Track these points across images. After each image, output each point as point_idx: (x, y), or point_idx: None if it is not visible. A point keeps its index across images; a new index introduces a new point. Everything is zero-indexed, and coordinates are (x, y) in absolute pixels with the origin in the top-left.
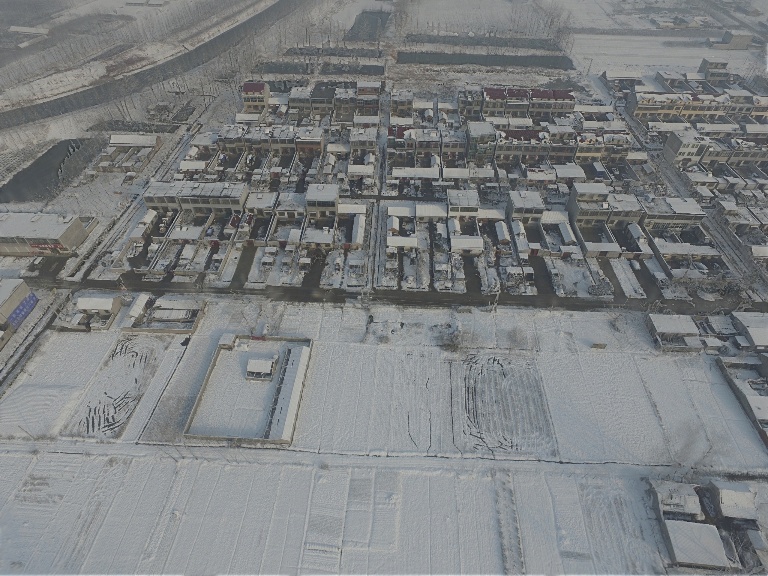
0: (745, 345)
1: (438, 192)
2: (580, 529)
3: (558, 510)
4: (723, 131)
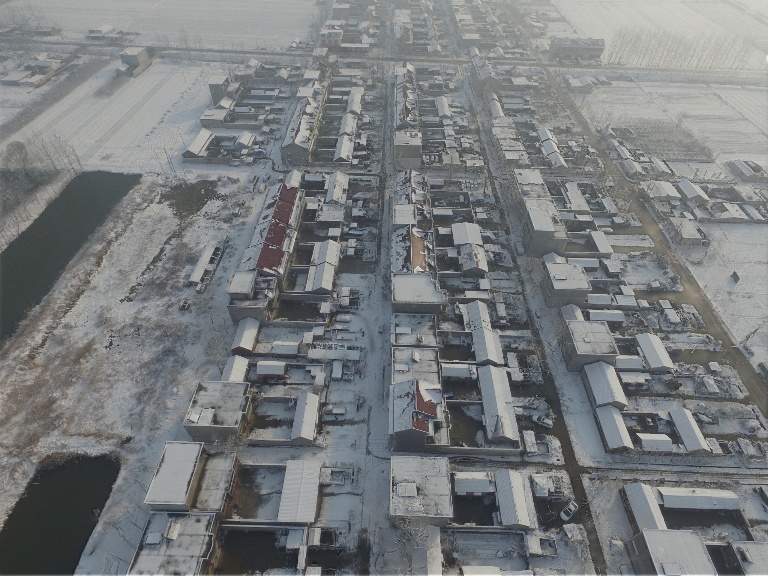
0: (679, 203)
1: None
2: None
3: None
4: (355, 124)
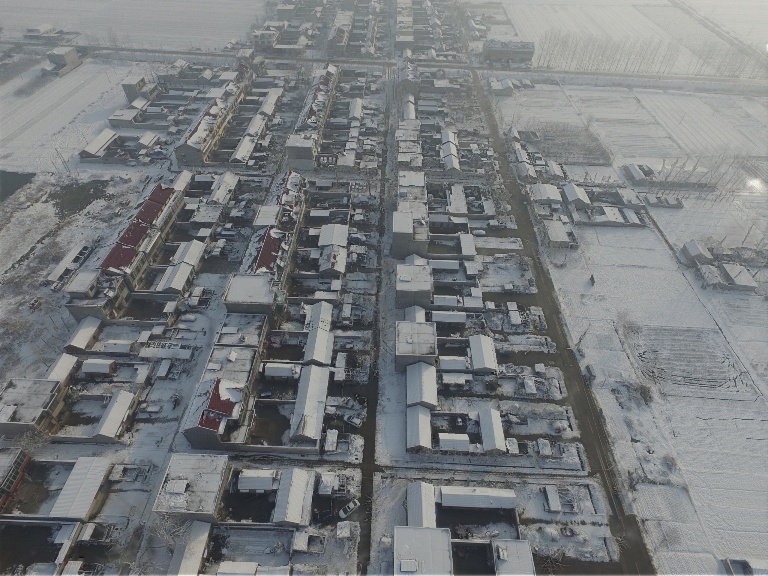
0: (560, 206)
1: (356, 377)
2: (767, 330)
3: (762, 339)
4: (262, 125)
